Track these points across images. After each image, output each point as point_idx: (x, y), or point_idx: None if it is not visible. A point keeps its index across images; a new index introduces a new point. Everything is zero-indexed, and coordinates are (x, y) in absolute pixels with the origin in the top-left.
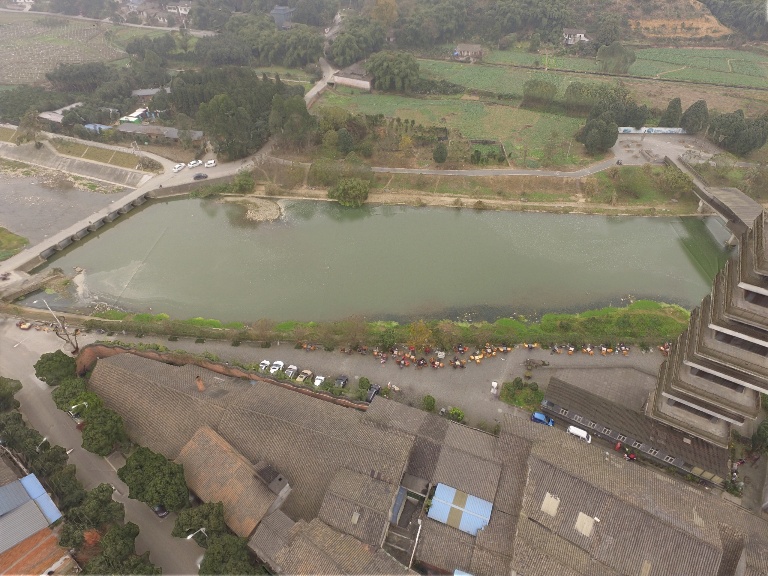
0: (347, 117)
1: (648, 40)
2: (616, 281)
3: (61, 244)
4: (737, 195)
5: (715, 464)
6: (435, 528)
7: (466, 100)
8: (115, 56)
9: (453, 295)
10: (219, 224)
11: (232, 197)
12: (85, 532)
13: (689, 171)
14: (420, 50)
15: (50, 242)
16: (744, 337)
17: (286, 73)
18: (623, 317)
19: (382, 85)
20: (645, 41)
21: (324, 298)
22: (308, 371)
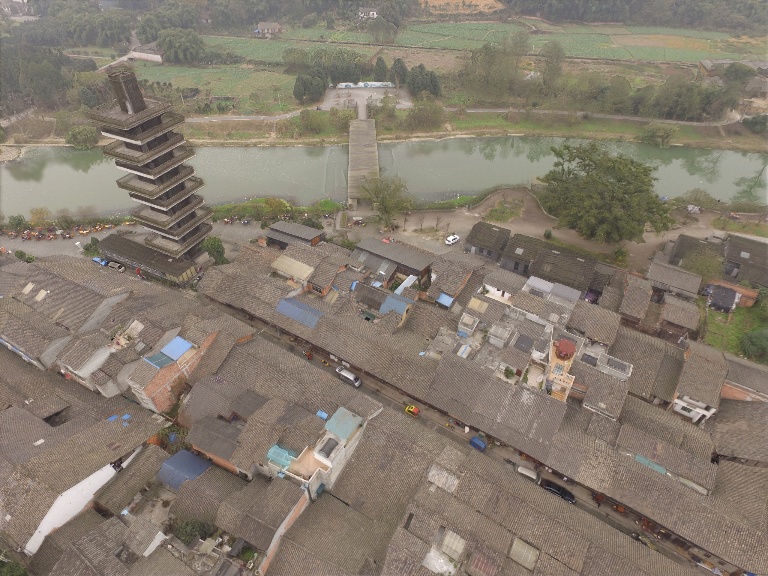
0: (101, 80)
1: (434, 16)
2: (252, 188)
3: None
4: (367, 123)
5: (176, 270)
6: None
7: (239, 68)
8: None
9: (117, 202)
10: None
11: None
12: None
13: (366, 112)
14: (229, 29)
15: None
16: None
17: (93, 51)
18: (231, 208)
19: (170, 58)
20: (431, 17)
21: (13, 209)
22: None
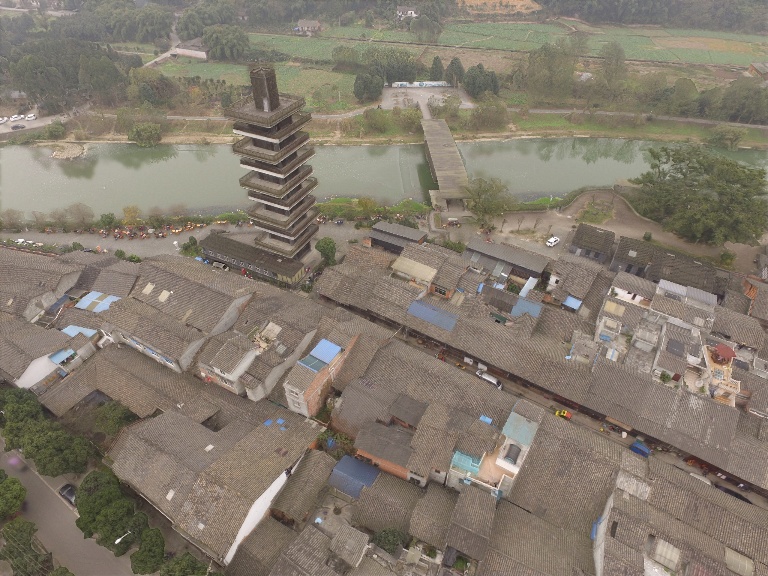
0: (157, 76)
1: (471, 16)
2: (329, 187)
3: None
4: (439, 123)
5: (289, 270)
6: (75, 311)
7: (287, 66)
8: None
9: (196, 201)
10: (25, 162)
11: (44, 142)
12: None
13: (429, 111)
14: (268, 26)
15: None
16: (256, 169)
17: (135, 47)
18: None
19: (215, 55)
20: (469, 17)
21: None
22: (40, 243)
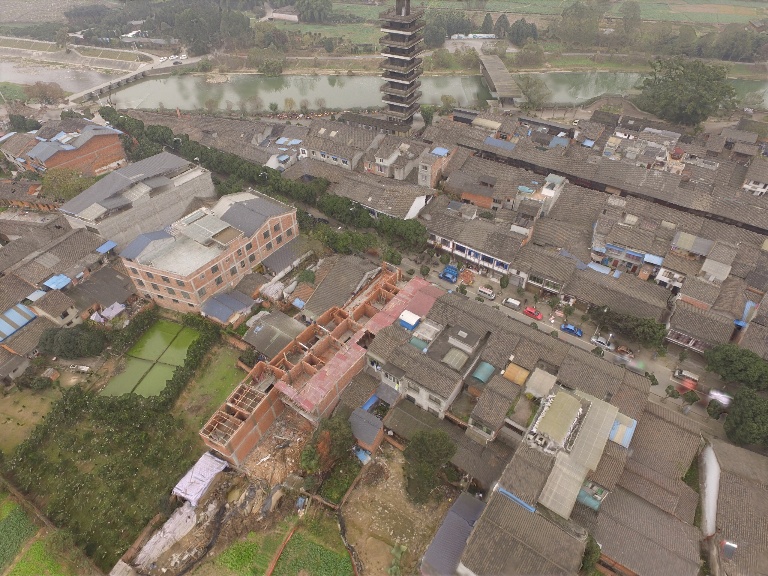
0: (273, 28)
1: None
2: None
3: (95, 93)
4: (493, 57)
5: None
6: None
7: (363, 26)
8: (110, 6)
9: (320, 106)
10: (189, 85)
11: (198, 73)
12: (133, 138)
13: (483, 53)
14: None
15: (88, 91)
16: (391, 56)
17: None
18: None
19: (306, 17)
20: None
21: None
22: None
